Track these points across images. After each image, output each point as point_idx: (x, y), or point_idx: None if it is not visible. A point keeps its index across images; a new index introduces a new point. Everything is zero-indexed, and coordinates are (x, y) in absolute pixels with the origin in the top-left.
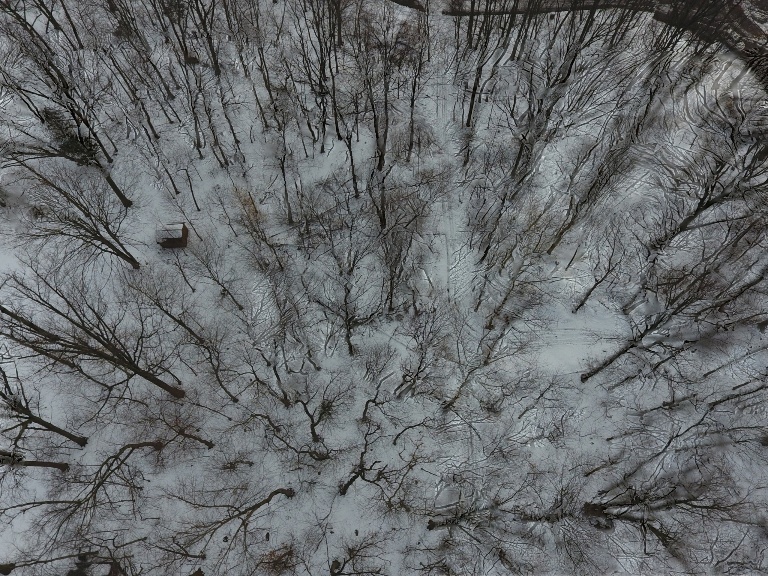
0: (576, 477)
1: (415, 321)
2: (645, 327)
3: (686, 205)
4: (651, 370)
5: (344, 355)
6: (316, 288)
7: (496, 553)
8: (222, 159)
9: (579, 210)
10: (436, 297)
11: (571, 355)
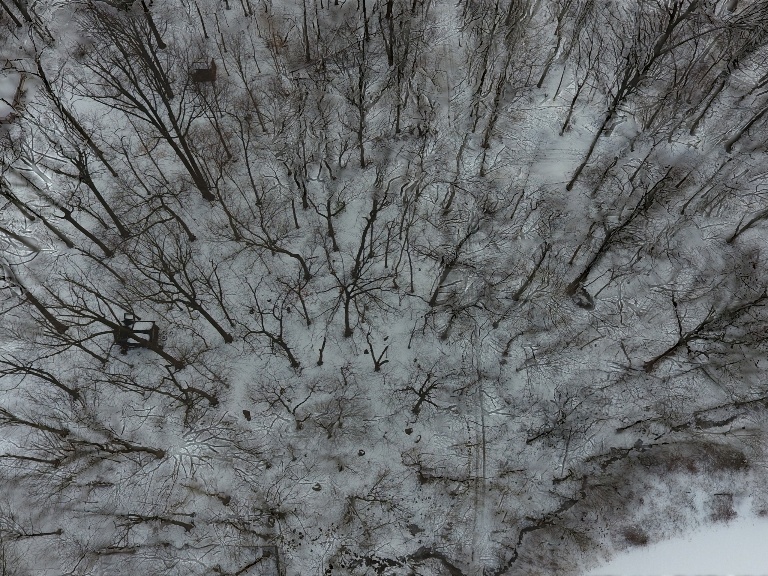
0: (561, 263)
1: (419, 141)
2: (617, 89)
3: (657, 18)
4: (629, 179)
5: (356, 167)
6: (331, 114)
7: (490, 324)
8: (247, 8)
9: (566, 48)
10: (438, 122)
11: (558, 169)
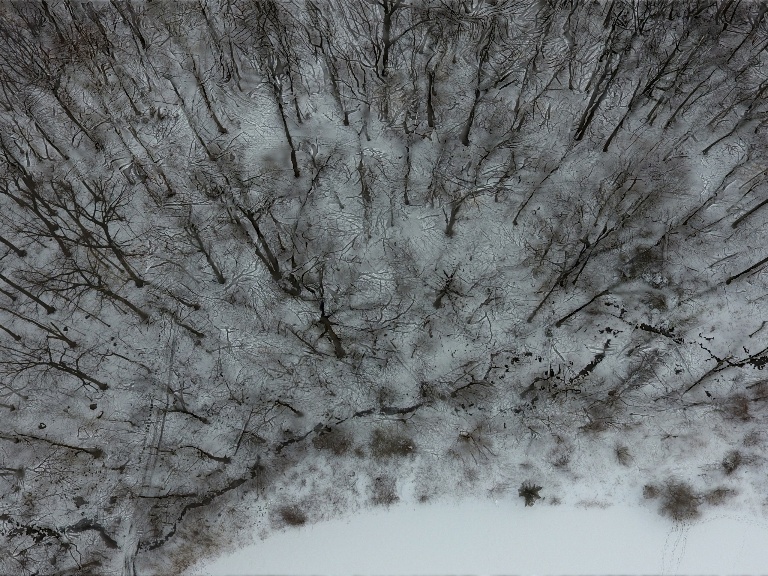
0: None
1: (158, 123)
2: (271, 75)
3: (366, 8)
4: (356, 168)
5: (91, 148)
6: (76, 94)
7: None
8: None
9: None
10: None
11: None
